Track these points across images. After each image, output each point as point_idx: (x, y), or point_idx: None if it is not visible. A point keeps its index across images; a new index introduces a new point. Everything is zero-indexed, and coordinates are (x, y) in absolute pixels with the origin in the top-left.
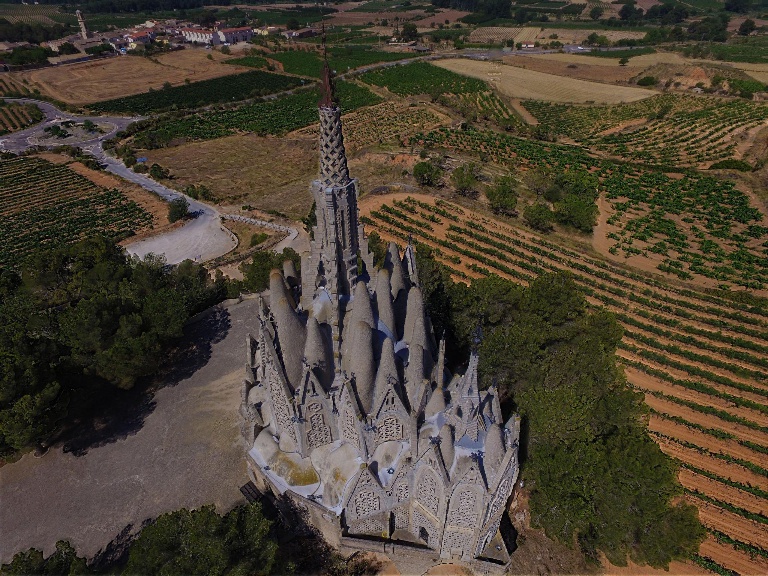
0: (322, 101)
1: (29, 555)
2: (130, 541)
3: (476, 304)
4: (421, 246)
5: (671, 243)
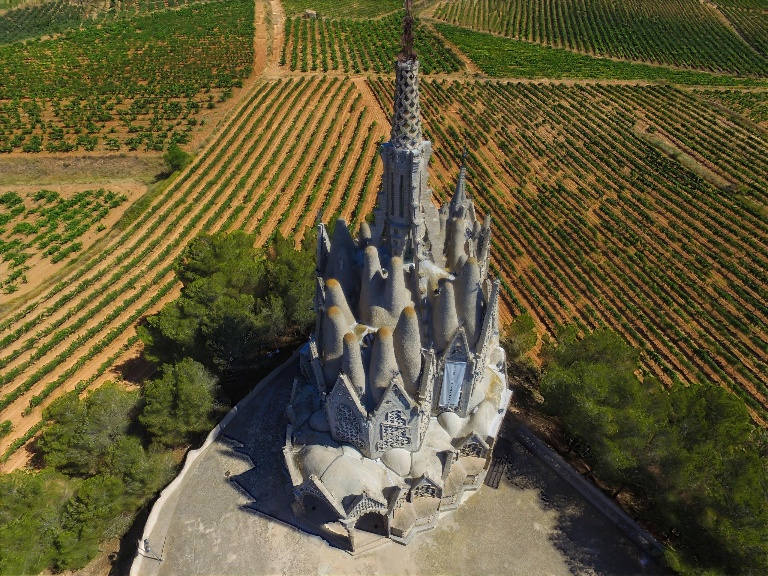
0: (412, 54)
1: (716, 526)
2: (598, 575)
3: (245, 297)
4: (54, 407)
5: (7, 250)
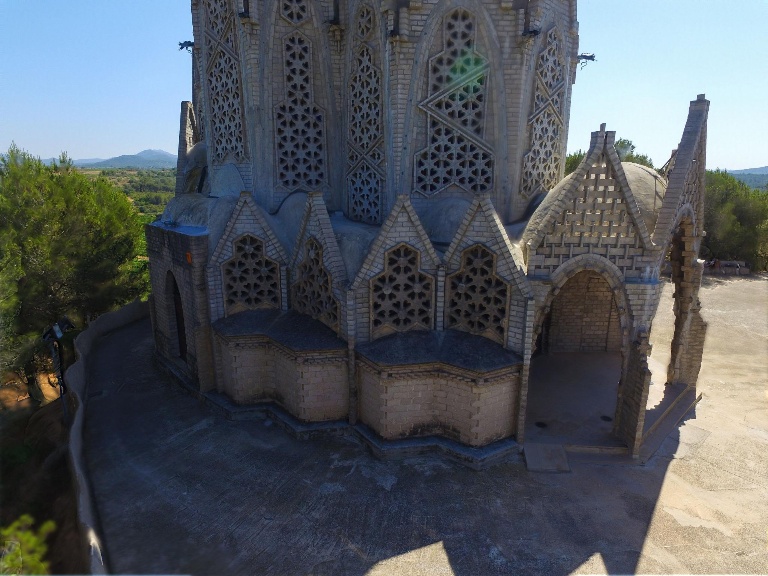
0: None
1: None
2: None
3: None
4: None
5: None
